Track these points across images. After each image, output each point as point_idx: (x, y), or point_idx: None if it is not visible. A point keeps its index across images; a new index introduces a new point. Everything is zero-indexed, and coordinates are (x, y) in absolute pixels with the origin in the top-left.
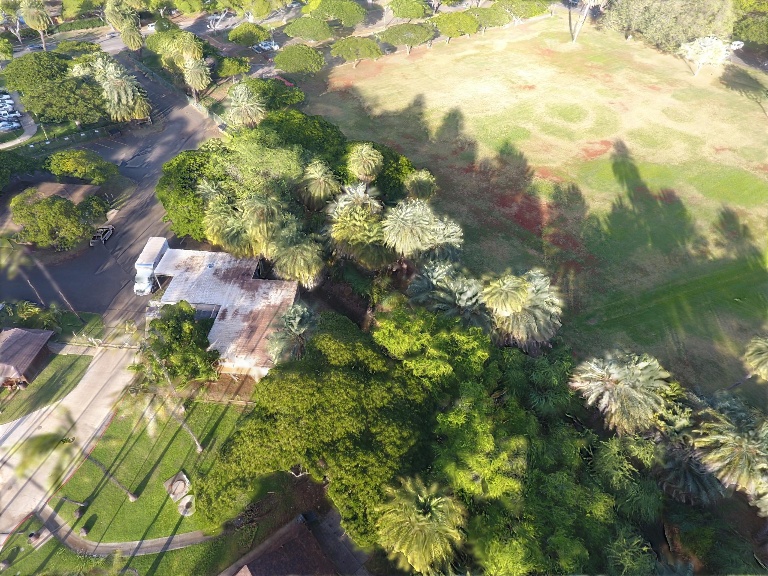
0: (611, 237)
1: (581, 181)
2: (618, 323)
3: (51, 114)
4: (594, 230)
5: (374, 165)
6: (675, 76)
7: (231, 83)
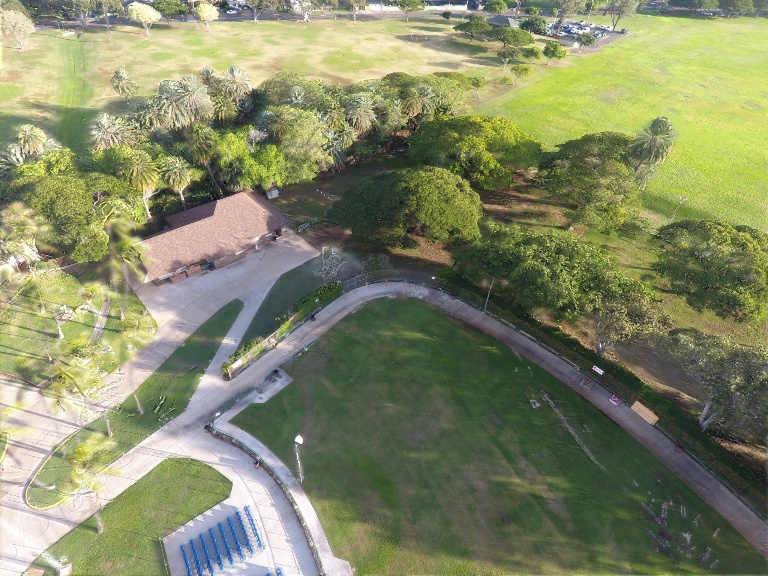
0: None
1: None
2: None
3: None
4: None
5: None
6: None
7: None
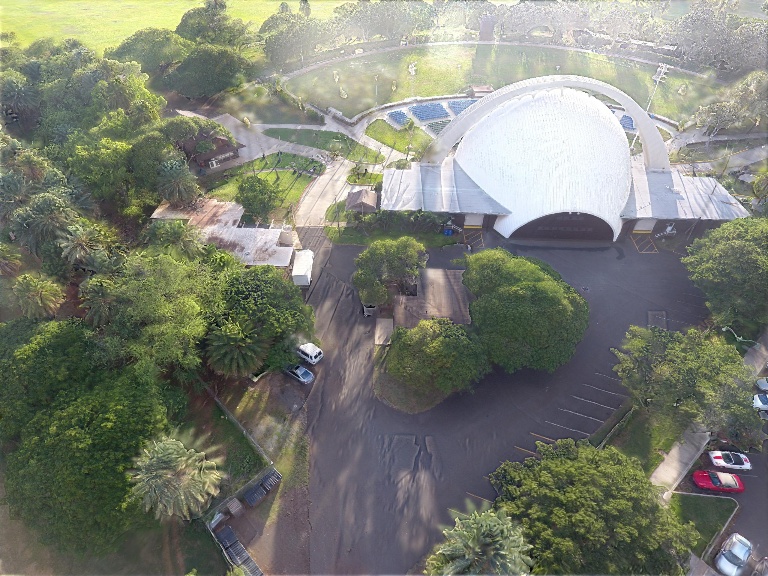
0: None
1: None
2: None
3: None
4: None
5: None
6: None
7: None
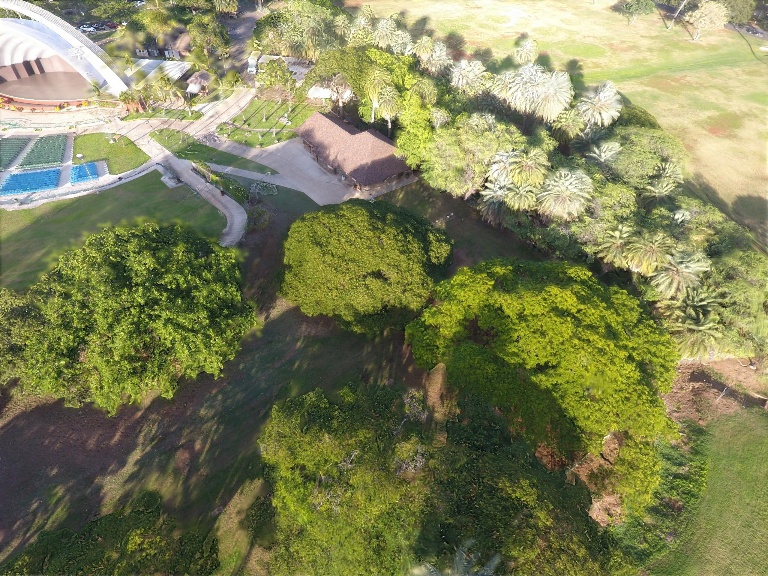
0: (501, 66)
1: (494, 46)
2: None
3: (185, 2)
4: (493, 63)
5: (370, 17)
6: (580, 4)
7: (281, 1)
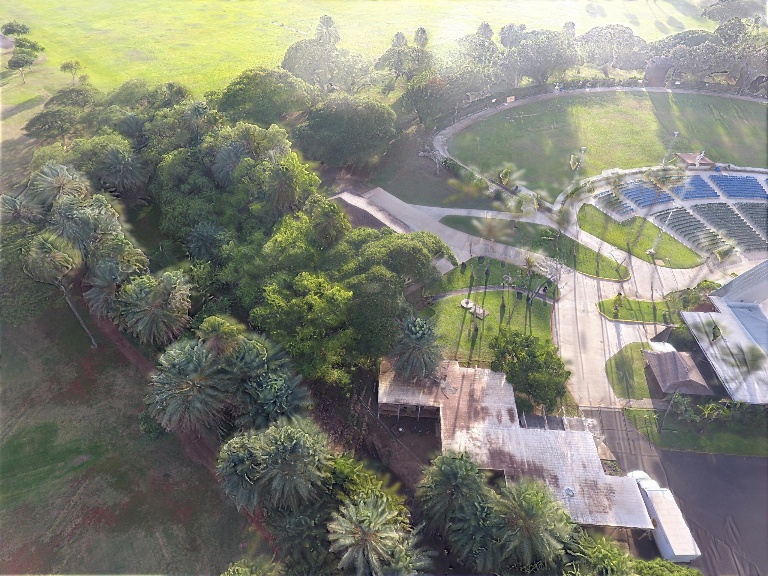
0: None
1: None
2: (51, 457)
3: None
4: None
5: None
6: None
7: None
